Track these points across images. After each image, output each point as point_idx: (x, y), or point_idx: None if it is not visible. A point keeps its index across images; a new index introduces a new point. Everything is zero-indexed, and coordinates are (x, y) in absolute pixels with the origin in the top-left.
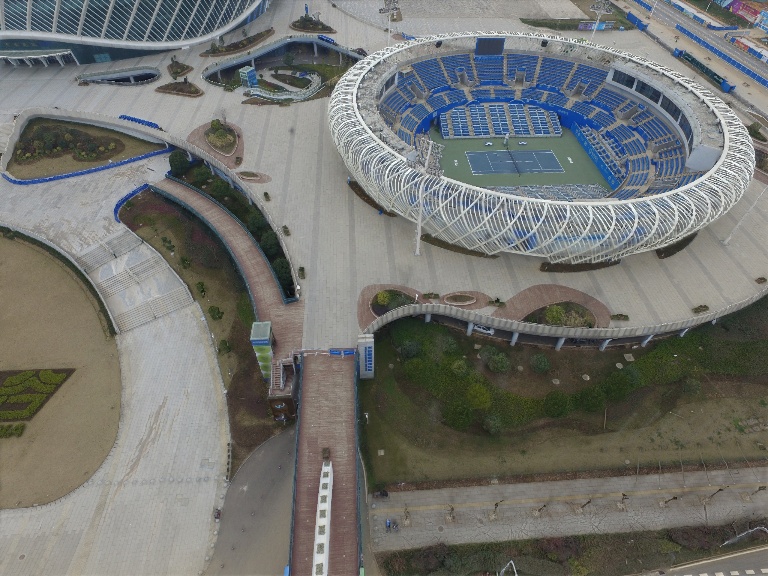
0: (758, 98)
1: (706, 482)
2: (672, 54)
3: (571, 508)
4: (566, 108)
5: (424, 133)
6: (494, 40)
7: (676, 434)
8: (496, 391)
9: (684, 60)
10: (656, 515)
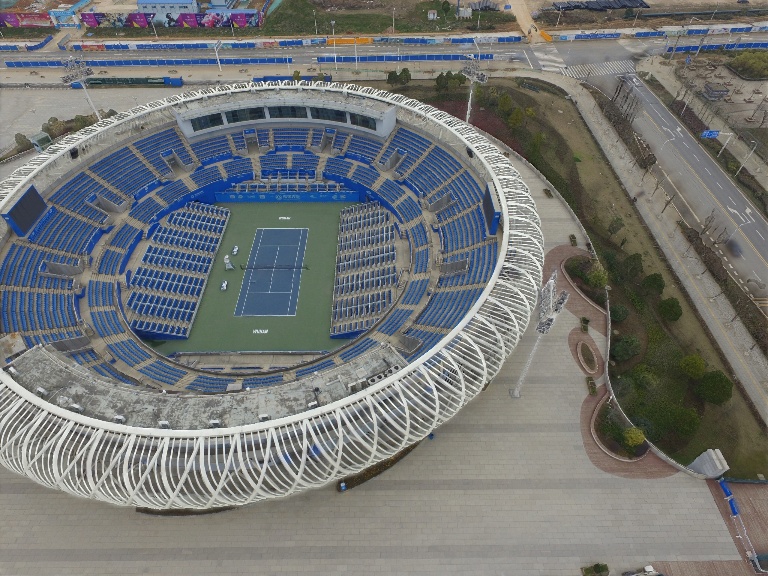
0: (201, 75)
1: (669, 250)
2: (72, 88)
3: (730, 330)
4: (196, 189)
5: (176, 360)
6: (24, 198)
7: (639, 252)
8: (653, 356)
9: (94, 86)
10: (709, 283)
